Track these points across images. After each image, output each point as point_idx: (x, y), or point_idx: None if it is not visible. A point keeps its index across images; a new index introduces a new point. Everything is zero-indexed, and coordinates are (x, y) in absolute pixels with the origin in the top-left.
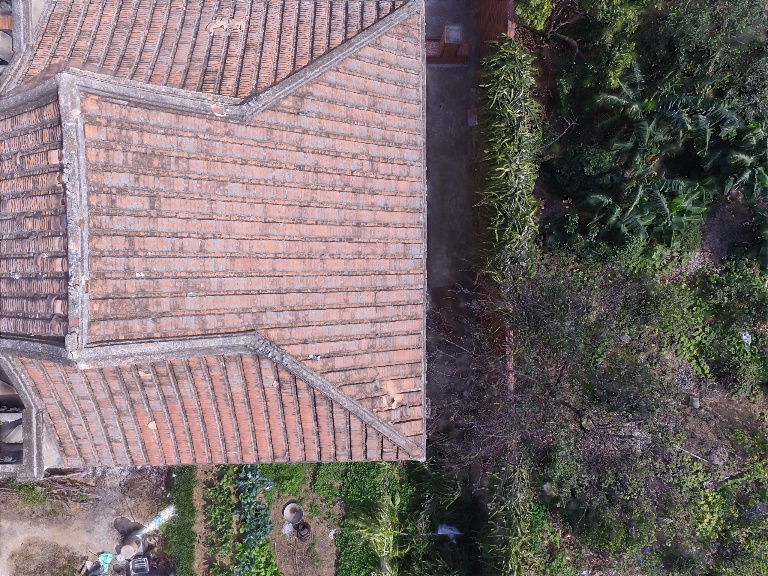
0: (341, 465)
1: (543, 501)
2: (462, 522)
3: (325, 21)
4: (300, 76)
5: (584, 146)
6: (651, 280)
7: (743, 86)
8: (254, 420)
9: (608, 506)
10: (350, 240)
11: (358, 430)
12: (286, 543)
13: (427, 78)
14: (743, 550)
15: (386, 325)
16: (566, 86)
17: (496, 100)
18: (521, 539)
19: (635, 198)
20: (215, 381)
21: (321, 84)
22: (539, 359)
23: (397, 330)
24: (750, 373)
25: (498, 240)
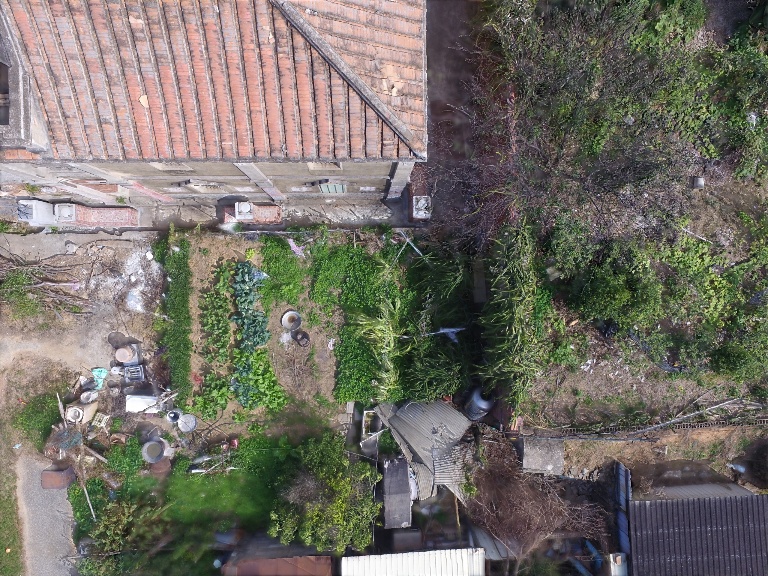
0: (340, 271)
1: (546, 286)
2: (464, 324)
3: None
4: None
5: None
6: (654, 57)
7: None
8: (250, 96)
9: (613, 276)
10: None
11: (357, 113)
12: (284, 353)
13: None
14: None
15: (385, 3)
16: None
17: None
18: (525, 298)
19: None
20: (209, 33)
21: None
22: (541, 141)
23: (396, 13)
24: (755, 146)
25: None
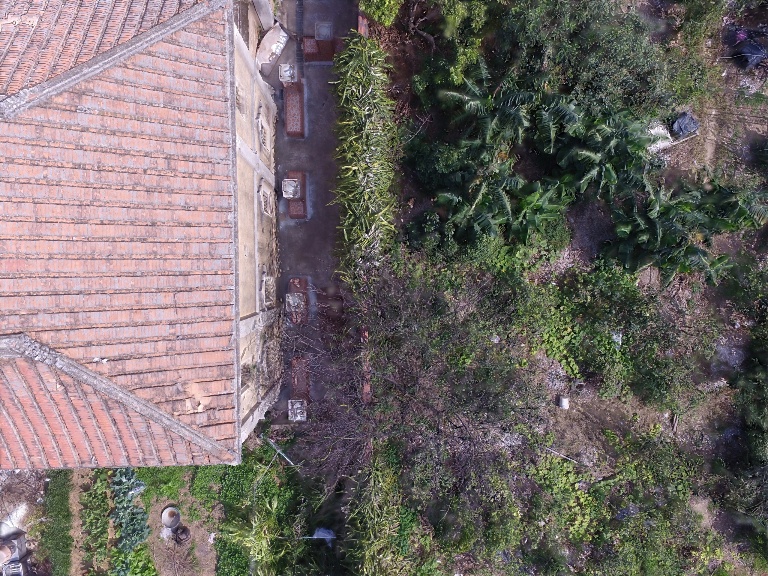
0: (219, 468)
1: (412, 504)
2: (339, 525)
3: (121, 16)
4: (75, 72)
5: (440, 143)
6: (518, 279)
7: (589, 82)
8: (50, 424)
9: (469, 509)
10: (144, 240)
11: (161, 434)
12: (165, 547)
13: (309, 76)
14: (616, 552)
15: (188, 327)
16: (419, 83)
17: (346, 97)
18: (373, 543)
19: (477, 196)
20: None
21: (105, 80)
22: (407, 360)
23: (202, 332)
24: (616, 373)
25: (347, 239)
